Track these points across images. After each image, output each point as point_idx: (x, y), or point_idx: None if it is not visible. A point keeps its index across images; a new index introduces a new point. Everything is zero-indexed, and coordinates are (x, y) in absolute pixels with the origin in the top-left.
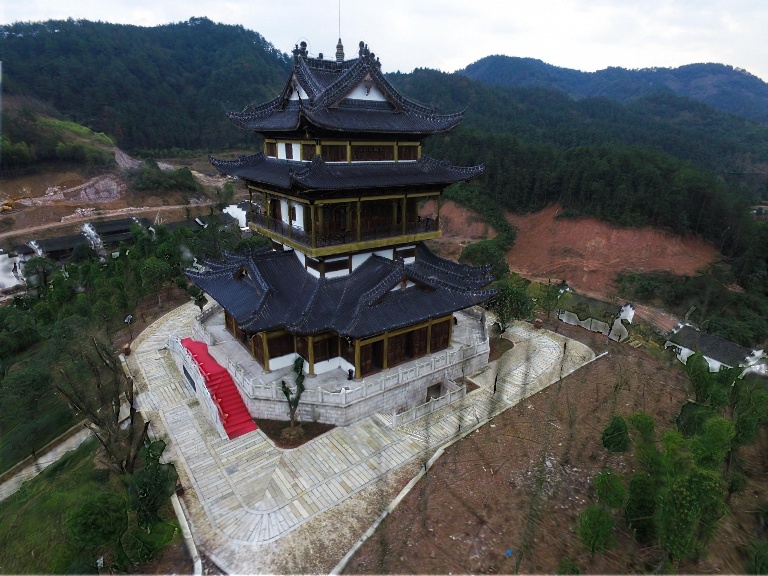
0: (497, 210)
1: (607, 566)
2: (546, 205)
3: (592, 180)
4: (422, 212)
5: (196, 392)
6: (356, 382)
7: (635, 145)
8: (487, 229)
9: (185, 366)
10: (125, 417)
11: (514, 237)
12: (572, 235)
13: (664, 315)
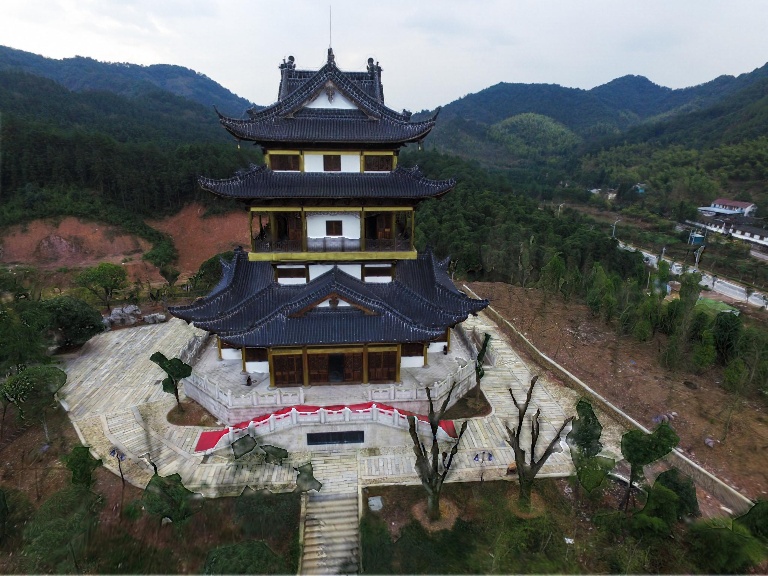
0: (135, 219)
1: None
2: (182, 206)
3: (226, 177)
4: (29, 237)
5: (364, 441)
6: (452, 353)
7: (197, 142)
8: (136, 241)
9: (324, 430)
10: (360, 503)
11: (172, 243)
12: (228, 230)
13: None
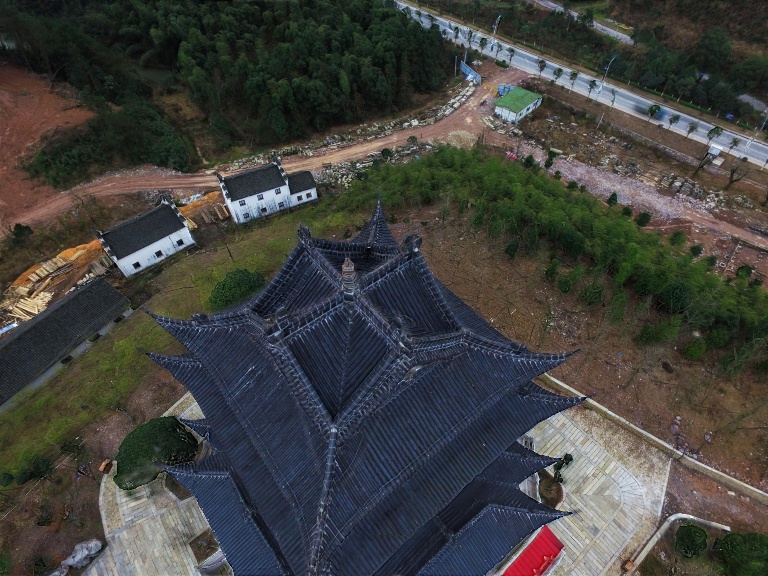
0: None
1: (609, 319)
2: None
3: None
4: None
5: None
6: None
7: None
8: None
9: None
10: None
11: None
12: None
13: (120, 176)
